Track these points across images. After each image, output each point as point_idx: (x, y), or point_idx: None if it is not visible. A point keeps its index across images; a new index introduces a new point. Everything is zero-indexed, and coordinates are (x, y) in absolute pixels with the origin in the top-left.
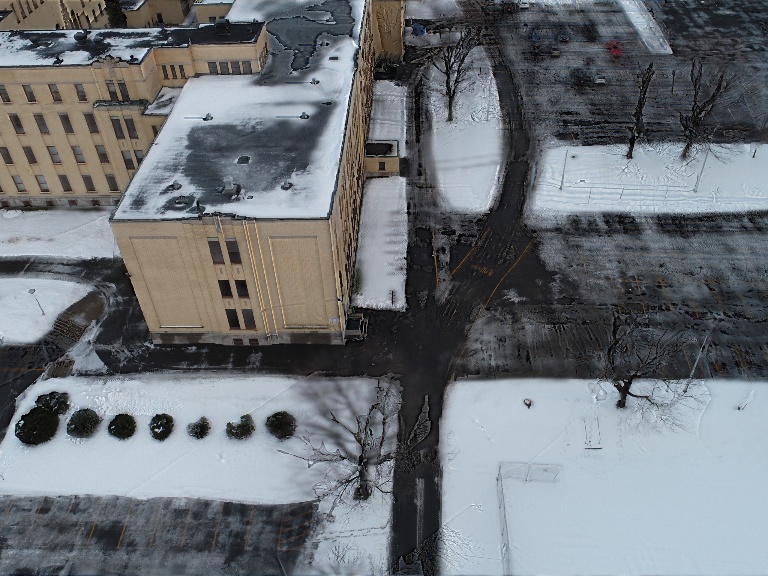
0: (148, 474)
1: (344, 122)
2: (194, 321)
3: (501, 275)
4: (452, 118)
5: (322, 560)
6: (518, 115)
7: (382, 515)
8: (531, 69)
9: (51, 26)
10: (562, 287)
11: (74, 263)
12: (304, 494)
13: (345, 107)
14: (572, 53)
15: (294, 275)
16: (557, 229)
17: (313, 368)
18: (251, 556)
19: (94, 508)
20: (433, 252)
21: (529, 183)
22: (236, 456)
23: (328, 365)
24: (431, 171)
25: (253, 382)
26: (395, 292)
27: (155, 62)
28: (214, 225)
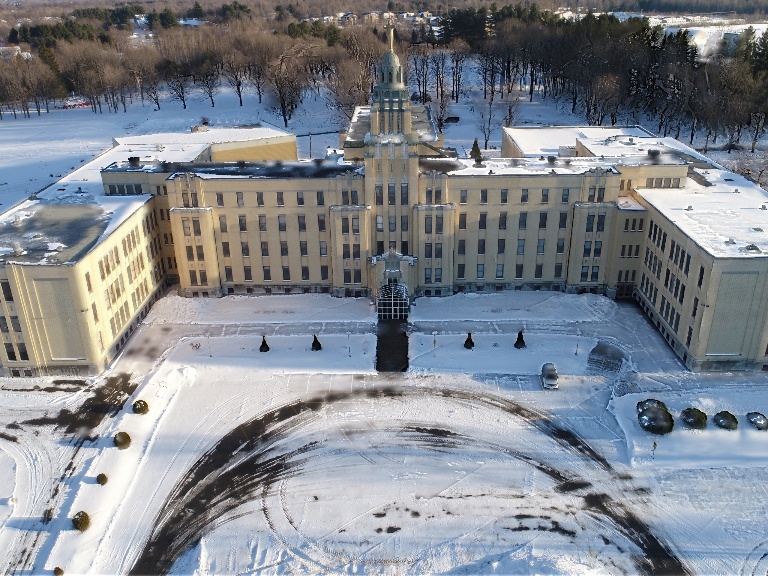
0: None
1: None
2: (735, 349)
3: None
4: None
5: None
6: None
7: None
8: None
9: None
10: None
11: (563, 324)
12: None
13: None
14: None
15: None
16: None
17: None
18: None
19: (750, 475)
20: None
21: None
22: None
23: None
24: None
25: None
26: None
27: None
28: None
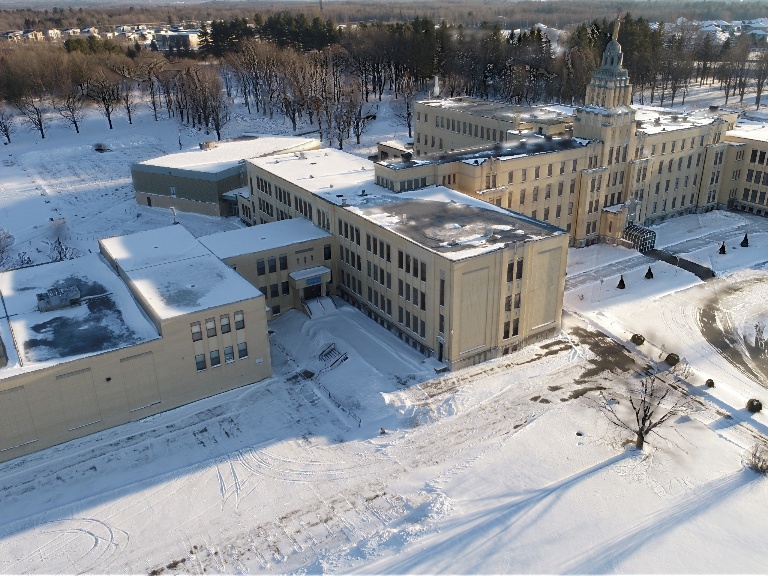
0: None
1: None
2: None
3: None
4: None
5: None
6: None
7: None
8: None
9: None
10: None
11: None
12: None
13: None
14: None
15: None
16: None
17: None
18: None
19: None
20: None
21: None
22: None
23: None
24: None
25: None
26: None
27: None
28: None
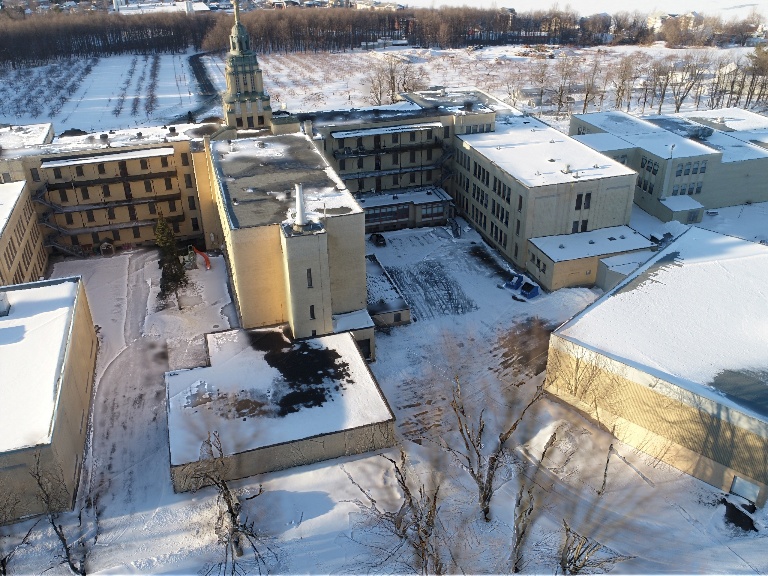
0: None
1: None
2: None
3: None
4: None
5: None
6: None
7: None
8: None
9: None
10: None
11: None
12: None
13: None
14: None
15: None
16: None
17: None
18: None
19: None
20: None
21: None
22: None
23: None
24: None
25: None
26: None
27: None
28: None
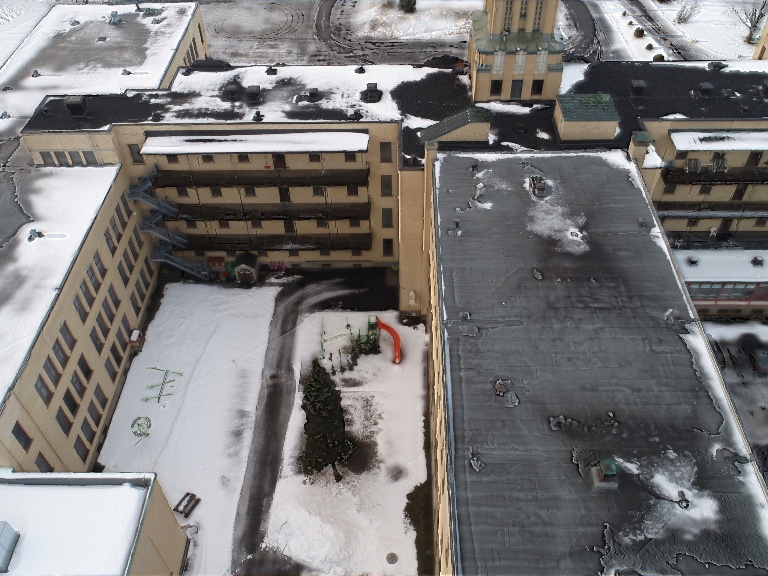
0: None
1: (5, 67)
2: None
3: None
4: None
5: None
6: None
7: None
8: None
9: None
10: None
11: None
12: None
13: None
14: None
15: None
16: None
17: None
18: None
19: None
20: None
21: None
22: None
23: None
24: None
25: None
26: None
27: None
28: None
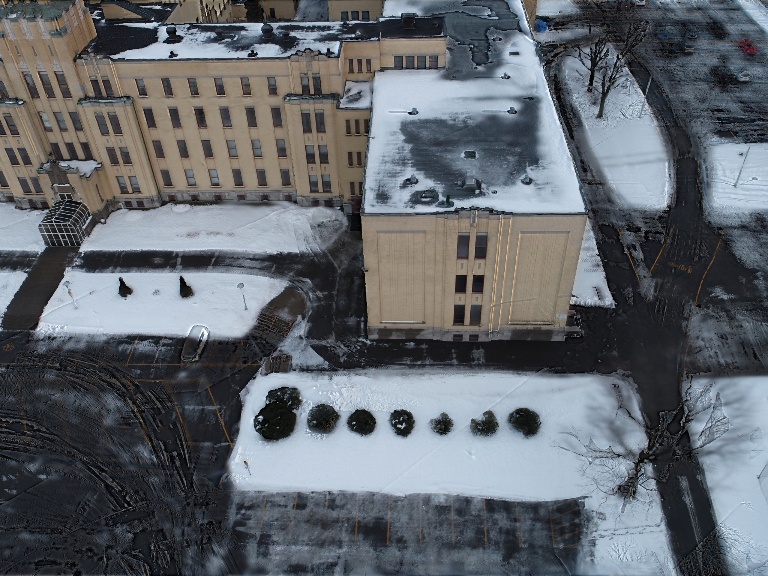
0: (399, 470)
1: (557, 117)
2: (417, 316)
3: (701, 272)
4: (602, 115)
5: (604, 558)
6: (669, 112)
7: (653, 513)
8: (667, 66)
9: (193, 19)
10: (767, 285)
11: (261, 258)
12: (566, 491)
13: (550, 102)
14: (704, 50)
15: (534, 271)
16: (743, 226)
17: (540, 364)
18: (528, 553)
19: (352, 504)
20: (624, 249)
21: (702, 180)
22: (485, 453)
23: (554, 362)
24: (596, 168)
25: (484, 378)
26: (599, 289)
27: (343, 56)
28: (469, 219)
